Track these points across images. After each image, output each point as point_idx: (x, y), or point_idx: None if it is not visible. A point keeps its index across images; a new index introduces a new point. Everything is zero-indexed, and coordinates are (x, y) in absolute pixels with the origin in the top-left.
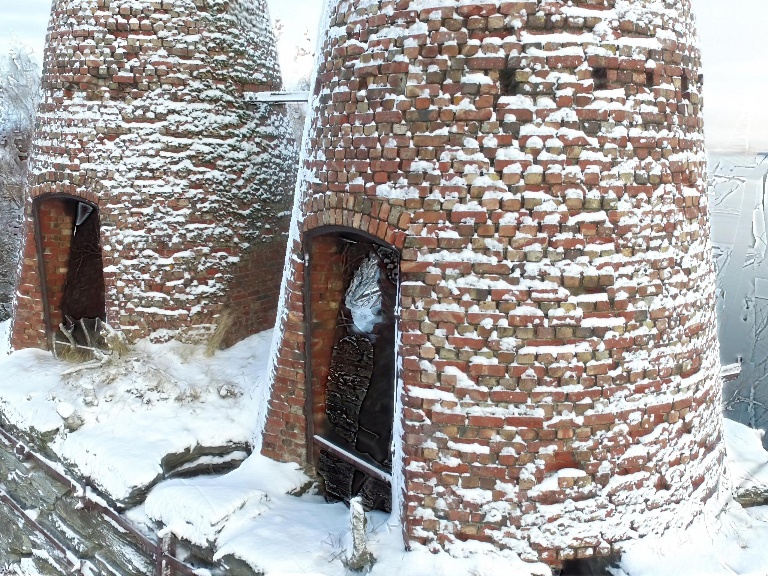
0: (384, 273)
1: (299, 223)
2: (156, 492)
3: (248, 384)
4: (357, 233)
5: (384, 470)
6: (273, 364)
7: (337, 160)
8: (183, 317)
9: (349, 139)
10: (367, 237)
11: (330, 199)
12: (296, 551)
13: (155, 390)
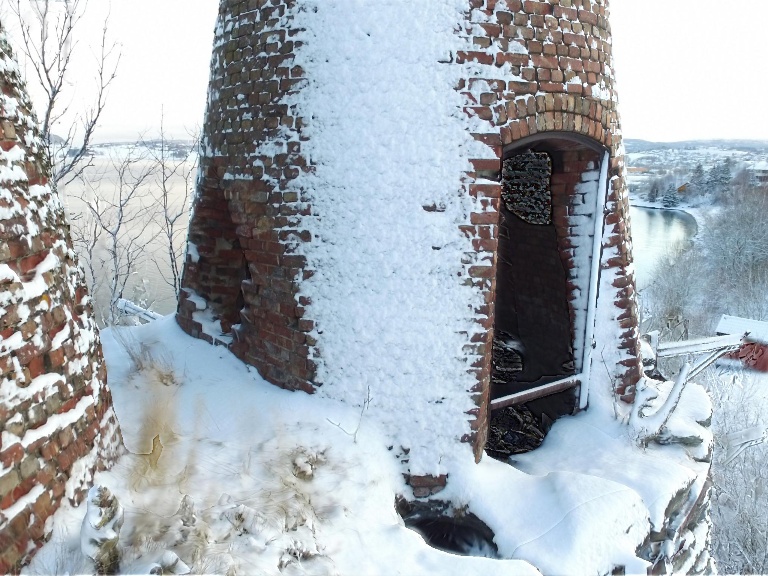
0: (230, 241)
1: (484, 135)
2: (573, 560)
3: (310, 438)
4: (564, 138)
5: (567, 376)
6: (468, 337)
7: (548, 55)
8: (91, 413)
9: (560, 33)
10: (574, 141)
11: (547, 101)
12: (654, 458)
13: (285, 533)
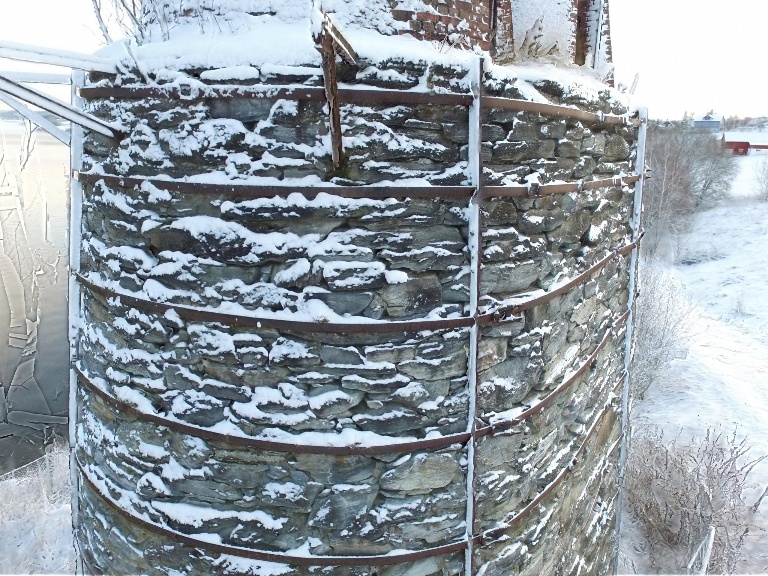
0: None
1: None
2: None
3: None
4: None
5: None
6: None
7: None
8: None
9: None
10: None
11: None
12: None
13: None
